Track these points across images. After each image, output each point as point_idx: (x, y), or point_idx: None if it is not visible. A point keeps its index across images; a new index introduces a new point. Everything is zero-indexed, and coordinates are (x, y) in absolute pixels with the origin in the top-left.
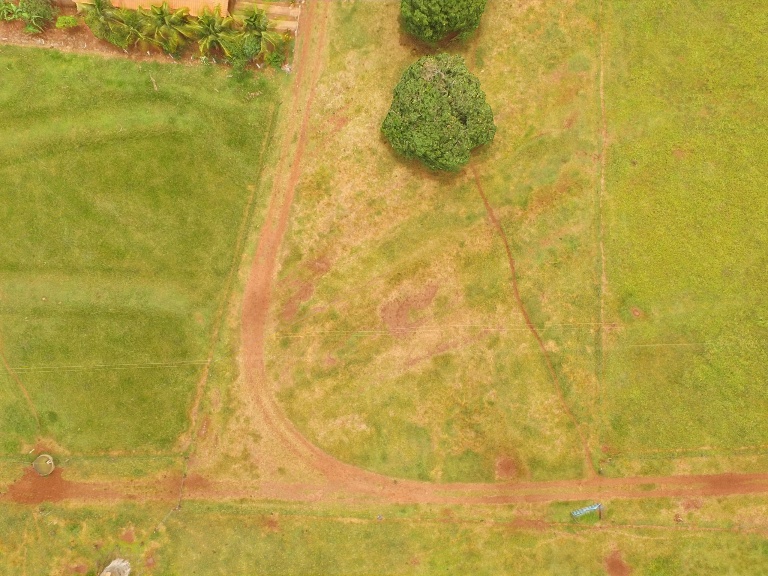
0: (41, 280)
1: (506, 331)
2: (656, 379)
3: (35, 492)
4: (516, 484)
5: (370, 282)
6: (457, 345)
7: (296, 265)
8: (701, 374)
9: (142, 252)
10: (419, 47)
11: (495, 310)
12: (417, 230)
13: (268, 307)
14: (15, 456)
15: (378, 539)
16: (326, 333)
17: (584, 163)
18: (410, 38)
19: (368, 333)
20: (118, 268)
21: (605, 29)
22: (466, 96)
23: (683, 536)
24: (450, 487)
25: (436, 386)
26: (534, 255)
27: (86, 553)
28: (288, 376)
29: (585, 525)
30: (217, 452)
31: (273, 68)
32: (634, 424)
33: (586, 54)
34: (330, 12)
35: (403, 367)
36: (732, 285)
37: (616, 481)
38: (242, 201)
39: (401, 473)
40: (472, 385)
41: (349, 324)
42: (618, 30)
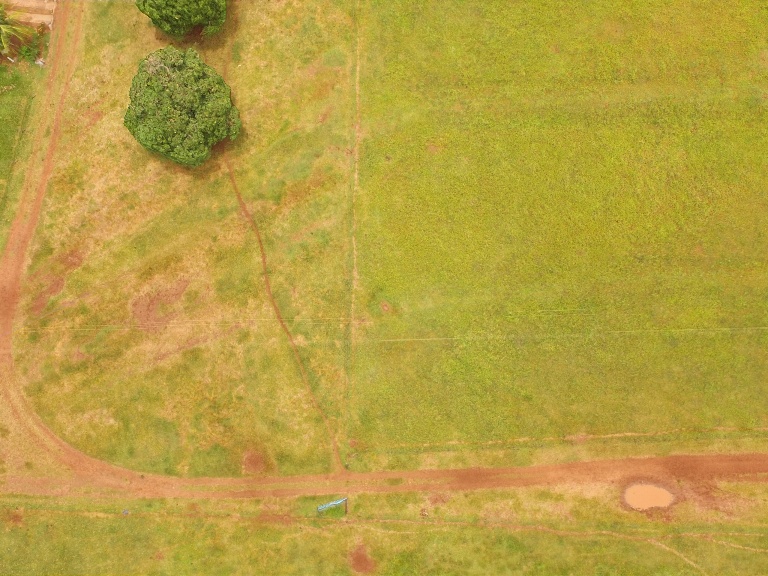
0: None
1: (257, 326)
2: (405, 374)
3: None
4: (264, 479)
5: (121, 276)
6: (207, 340)
7: (47, 259)
8: (449, 369)
9: None
10: (175, 41)
11: (246, 305)
12: (169, 224)
13: (18, 301)
14: None
15: (123, 534)
16: (76, 327)
17: (337, 158)
18: (164, 32)
19: (117, 327)
20: None
21: (361, 24)
22: (185, 90)
23: (429, 530)
24: (197, 482)
25: (185, 381)
26: (285, 250)
27: None
28: (37, 370)
29: (331, 519)
30: None
31: (27, 62)
32: (382, 419)
33: (342, 49)
34: (86, 6)
35: (153, 362)
36: (482, 280)
37: (364, 476)
38: None
39: (148, 468)
40: (221, 380)
41: (100, 318)
42: (375, 25)
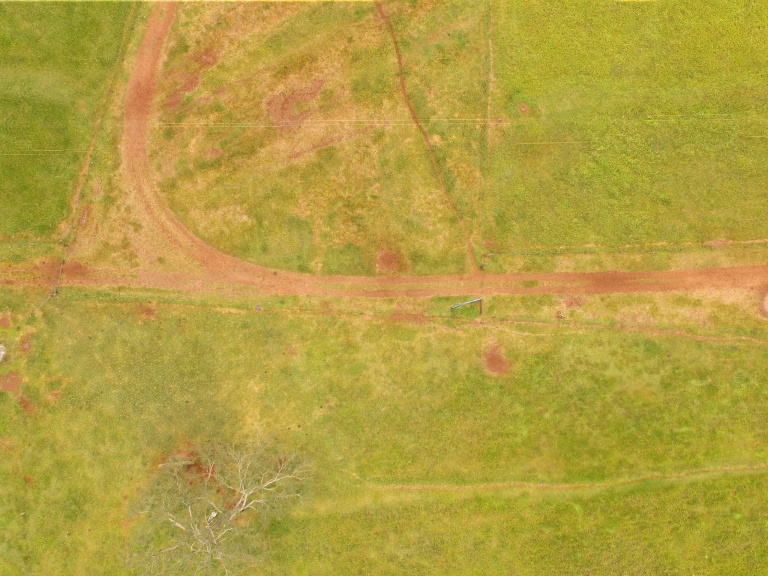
0: None
1: (391, 126)
2: (542, 176)
3: None
4: (397, 278)
5: (256, 74)
6: (341, 139)
7: (182, 57)
8: (587, 171)
9: (28, 41)
10: None
11: (381, 105)
12: (305, 24)
13: (153, 98)
14: None
15: (256, 329)
16: (210, 125)
17: None
18: None
19: (252, 124)
20: (3, 56)
21: None
22: None
23: (564, 333)
24: (330, 280)
25: (319, 179)
26: (422, 50)
27: None
28: (171, 166)
29: (465, 320)
30: (97, 240)
31: None
32: (518, 220)
33: None
34: None
35: (287, 160)
36: (621, 83)
37: (498, 277)
38: None
39: (281, 264)
40: (356, 179)
41: (234, 116)
42: None
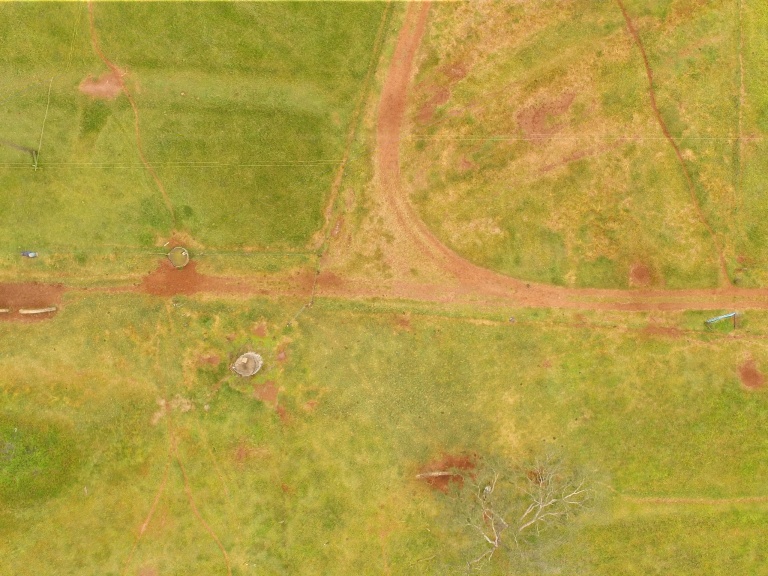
0: (179, 76)
1: (642, 140)
2: None
3: (169, 285)
4: (650, 292)
5: (507, 88)
6: (593, 152)
7: (432, 70)
8: None
9: (280, 52)
10: None
11: (631, 119)
12: (554, 38)
13: (404, 110)
14: (150, 248)
15: (510, 341)
16: (461, 137)
17: None
18: None
19: (504, 137)
20: (255, 68)
21: None
22: None
23: None
24: (583, 293)
25: (571, 192)
26: (673, 65)
27: (219, 345)
28: (422, 178)
29: (719, 334)
30: (350, 251)
31: None
32: None
33: None
34: None
35: (538, 173)
36: None
37: (751, 292)
38: (380, 5)
39: (534, 277)
40: (607, 192)
41: (484, 129)
42: None
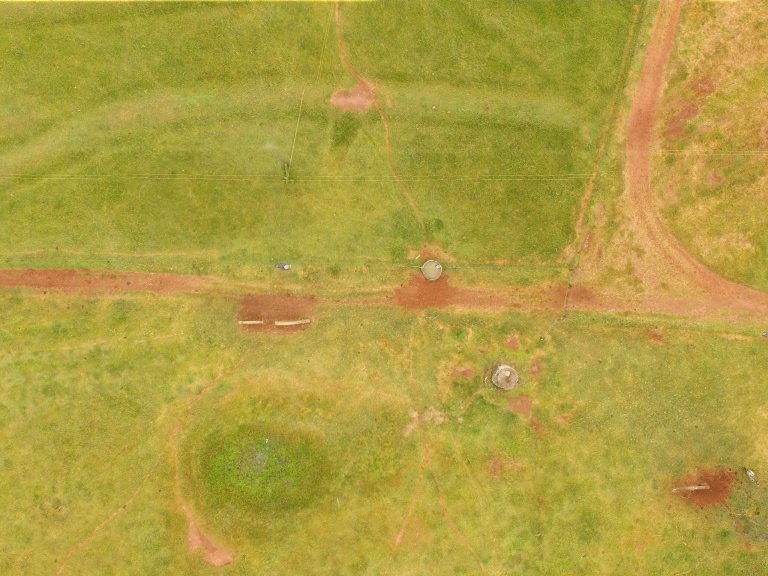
0: (429, 90)
1: None
2: None
3: (420, 297)
4: None
5: (756, 103)
6: None
7: (681, 85)
8: None
9: (528, 67)
10: None
11: None
12: None
13: (653, 125)
14: (402, 261)
15: (763, 356)
16: (710, 152)
17: None
18: None
19: (755, 153)
20: (504, 82)
21: None
22: None
23: None
24: None
25: None
26: None
27: (473, 358)
28: (673, 193)
29: None
30: (601, 265)
31: None
32: None
33: None
34: None
35: None
36: None
37: None
38: (627, 20)
39: None
40: None
41: (733, 144)
42: None
